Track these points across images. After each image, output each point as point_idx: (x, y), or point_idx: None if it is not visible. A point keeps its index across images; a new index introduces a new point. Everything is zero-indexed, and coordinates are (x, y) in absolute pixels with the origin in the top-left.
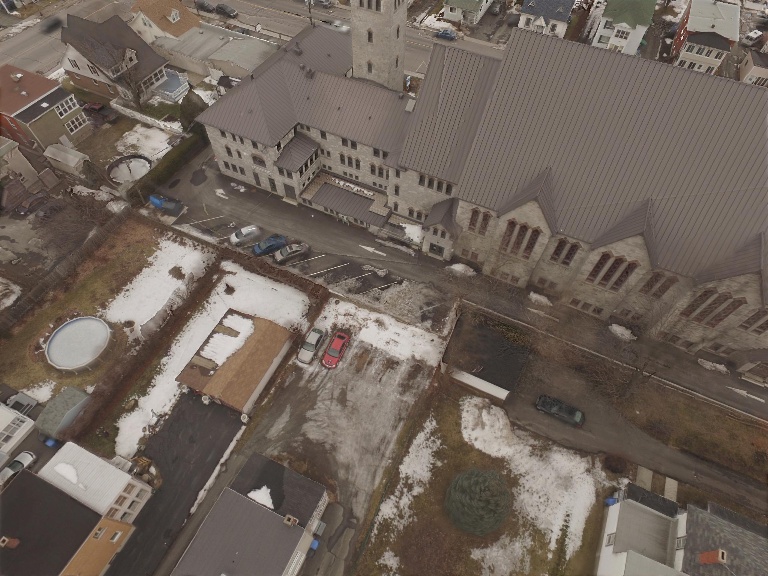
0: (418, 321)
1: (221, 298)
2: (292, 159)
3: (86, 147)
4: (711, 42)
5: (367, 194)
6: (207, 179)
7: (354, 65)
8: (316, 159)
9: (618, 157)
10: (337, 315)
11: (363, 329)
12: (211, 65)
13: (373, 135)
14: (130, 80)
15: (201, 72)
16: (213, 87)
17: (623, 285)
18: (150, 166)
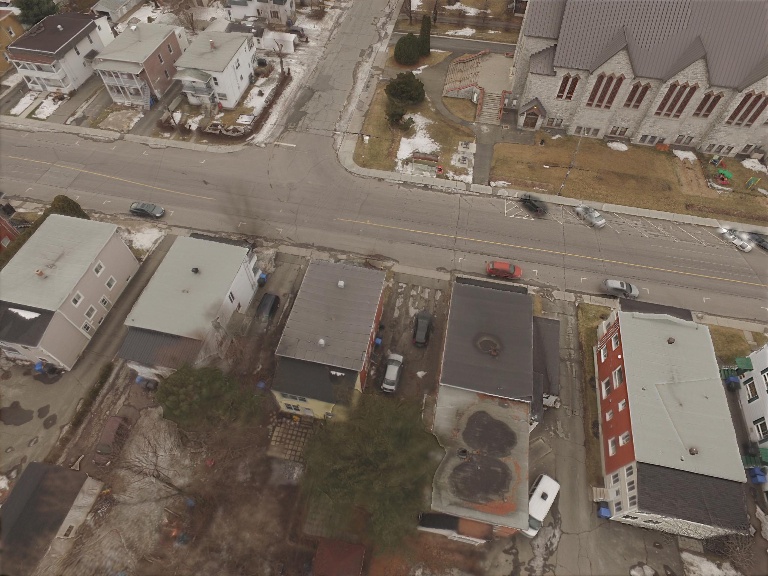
0: None
1: None
2: None
3: None
4: (657, 308)
5: None
6: None
7: None
8: None
9: None
10: None
11: None
12: None
13: None
14: None
15: None
16: None
17: None
18: None
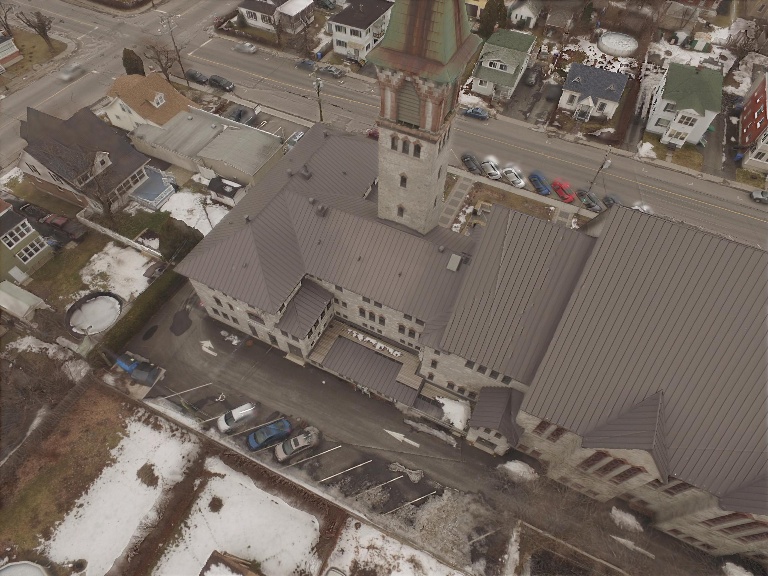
0: (467, 561)
1: (204, 518)
2: (298, 320)
3: (44, 277)
4: None
5: (393, 354)
6: (191, 325)
7: (379, 206)
8: (328, 309)
9: (766, 392)
10: (358, 548)
11: (393, 573)
12: (201, 162)
13: (404, 297)
14: (99, 193)
15: (189, 168)
16: (203, 187)
17: (757, 542)
18: (120, 308)
